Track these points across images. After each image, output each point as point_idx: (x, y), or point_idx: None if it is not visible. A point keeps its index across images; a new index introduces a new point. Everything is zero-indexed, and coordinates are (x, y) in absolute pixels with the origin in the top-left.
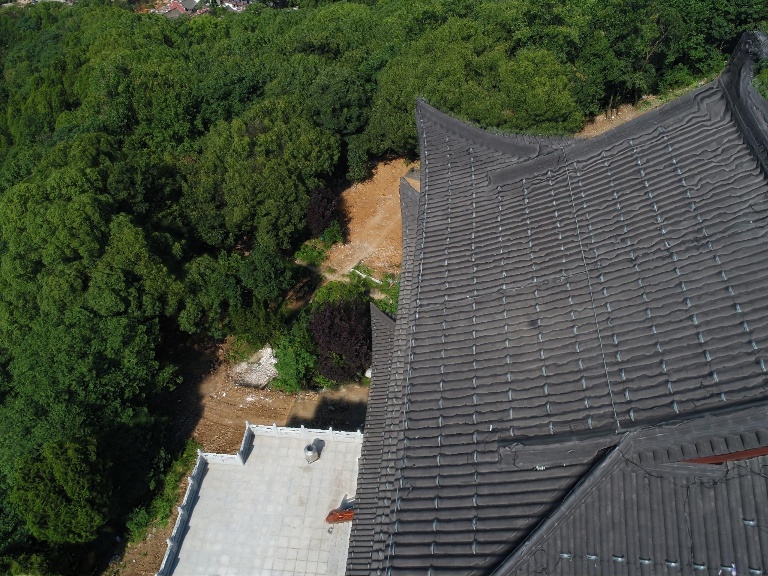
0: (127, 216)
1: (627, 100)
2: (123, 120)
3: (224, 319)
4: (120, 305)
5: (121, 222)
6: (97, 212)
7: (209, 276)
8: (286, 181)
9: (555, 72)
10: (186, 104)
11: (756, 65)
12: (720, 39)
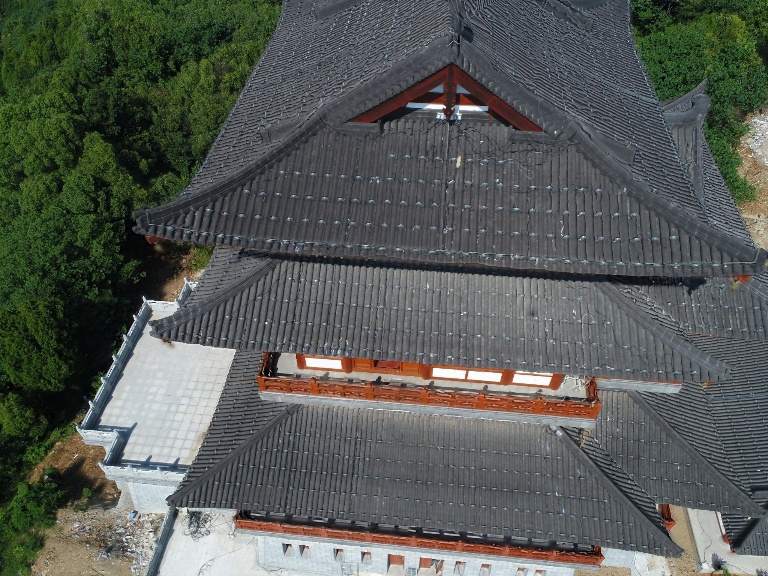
0: (99, 134)
1: None
2: (103, 62)
3: None
4: (90, 204)
5: (93, 138)
6: (72, 127)
7: (172, 189)
8: None
9: None
10: (159, 45)
11: (691, 22)
12: (666, 1)
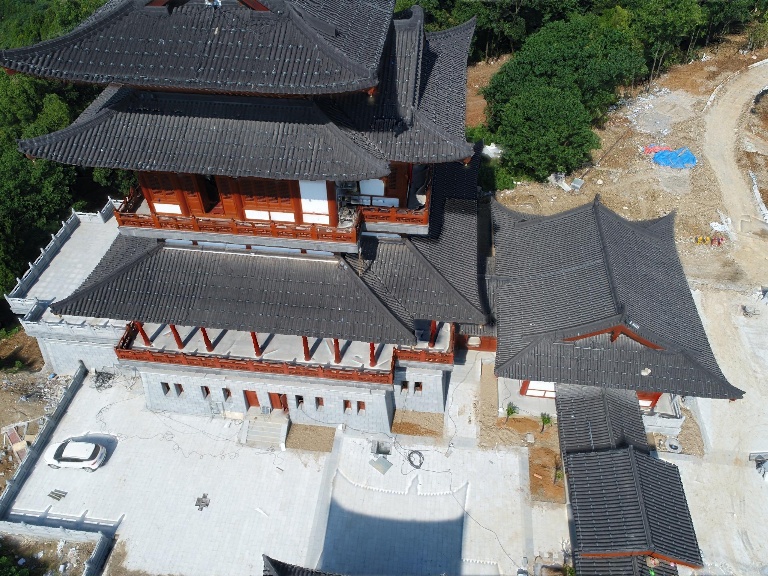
0: None
1: (508, 51)
2: None
3: (131, 179)
4: None
5: (52, 98)
6: (33, 88)
7: None
8: None
9: (408, 6)
10: None
11: None
12: (589, 2)
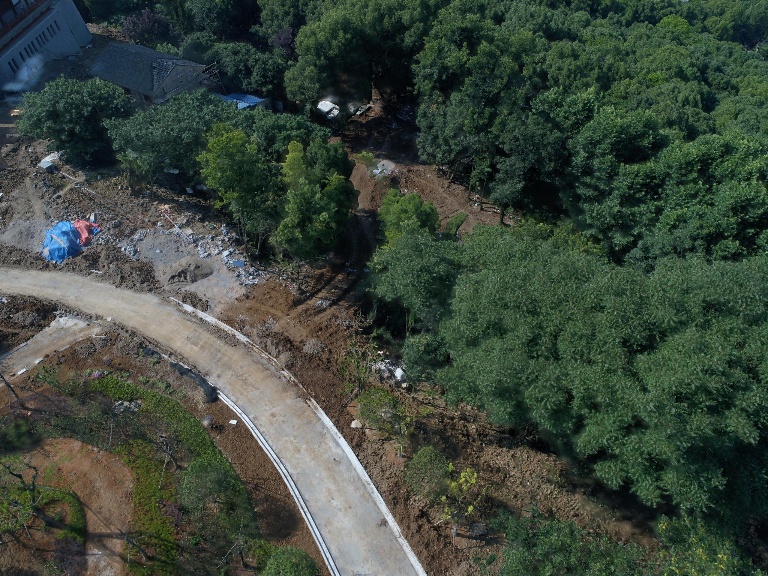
0: None
1: (519, 220)
2: None
3: None
4: None
5: None
6: None
7: None
8: (285, 6)
9: None
10: None
11: None
12: None
